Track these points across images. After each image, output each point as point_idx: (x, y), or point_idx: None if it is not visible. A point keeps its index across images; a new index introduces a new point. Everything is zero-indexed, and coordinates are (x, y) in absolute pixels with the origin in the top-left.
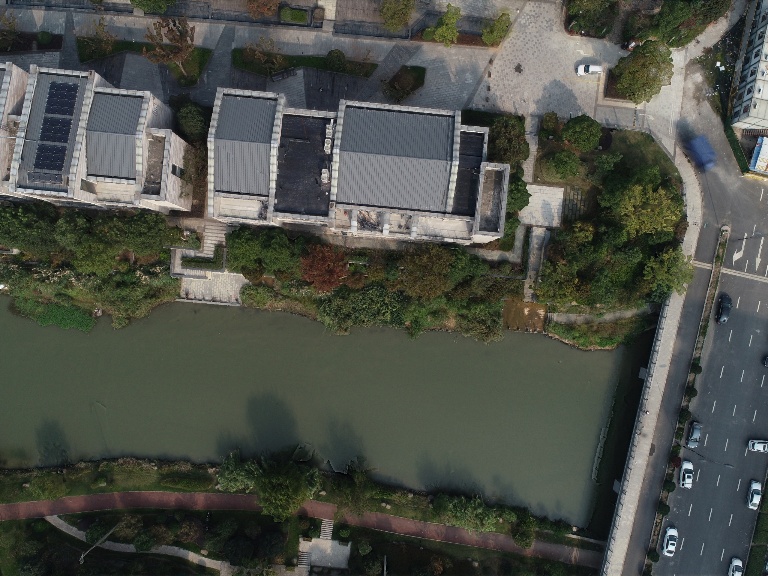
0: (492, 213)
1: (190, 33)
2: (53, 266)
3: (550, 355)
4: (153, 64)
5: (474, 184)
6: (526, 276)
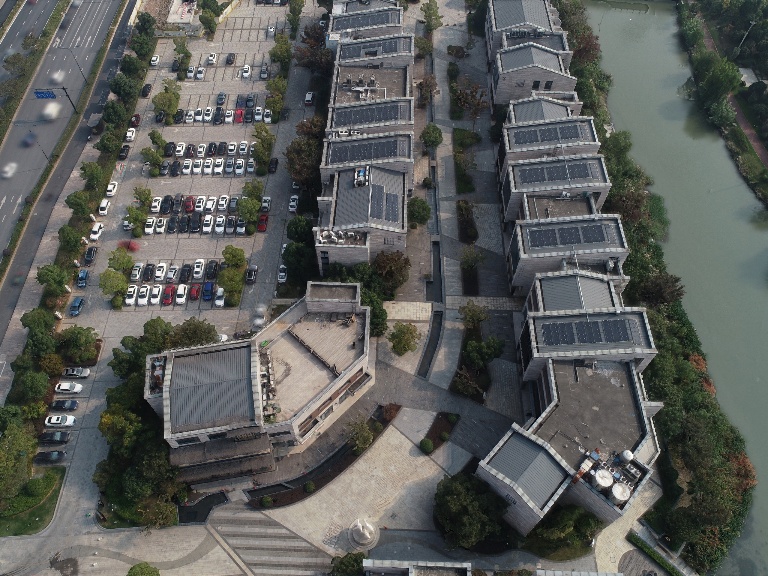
0: None
1: None
2: None
3: None
4: None
5: None
6: None
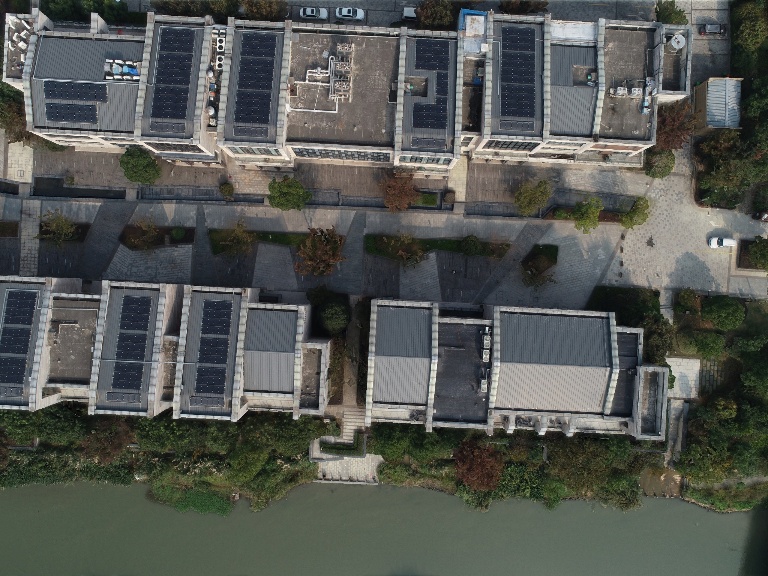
0: (649, 411)
1: (339, 243)
2: (194, 458)
3: (687, 518)
4: (286, 253)
5: (630, 384)
6: (666, 449)
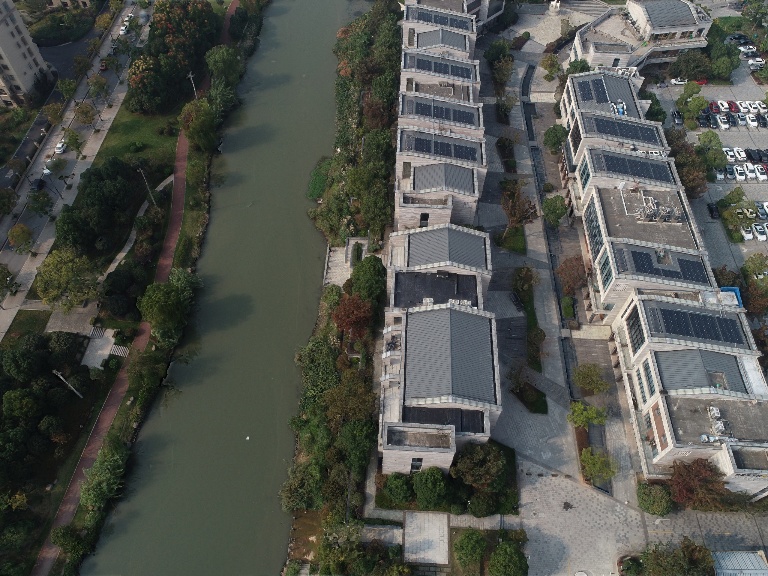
0: None
1: (528, 221)
2: None
3: (263, 571)
4: (507, 221)
5: None
6: None
